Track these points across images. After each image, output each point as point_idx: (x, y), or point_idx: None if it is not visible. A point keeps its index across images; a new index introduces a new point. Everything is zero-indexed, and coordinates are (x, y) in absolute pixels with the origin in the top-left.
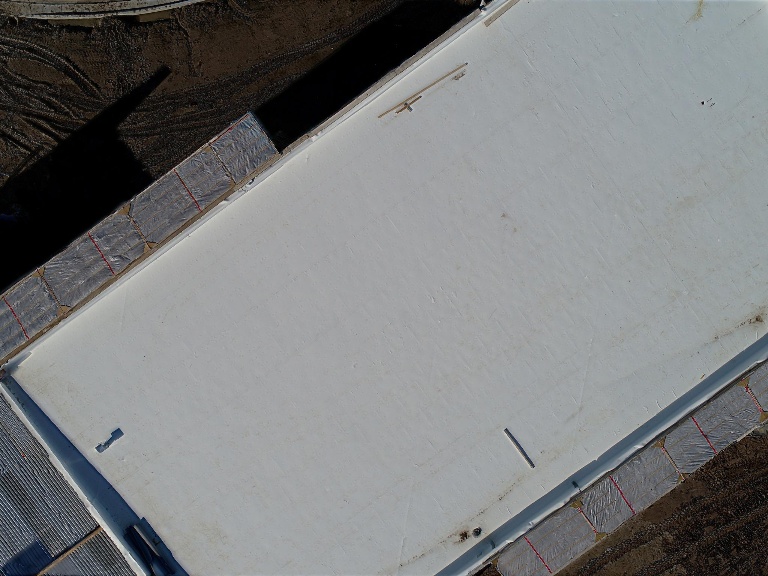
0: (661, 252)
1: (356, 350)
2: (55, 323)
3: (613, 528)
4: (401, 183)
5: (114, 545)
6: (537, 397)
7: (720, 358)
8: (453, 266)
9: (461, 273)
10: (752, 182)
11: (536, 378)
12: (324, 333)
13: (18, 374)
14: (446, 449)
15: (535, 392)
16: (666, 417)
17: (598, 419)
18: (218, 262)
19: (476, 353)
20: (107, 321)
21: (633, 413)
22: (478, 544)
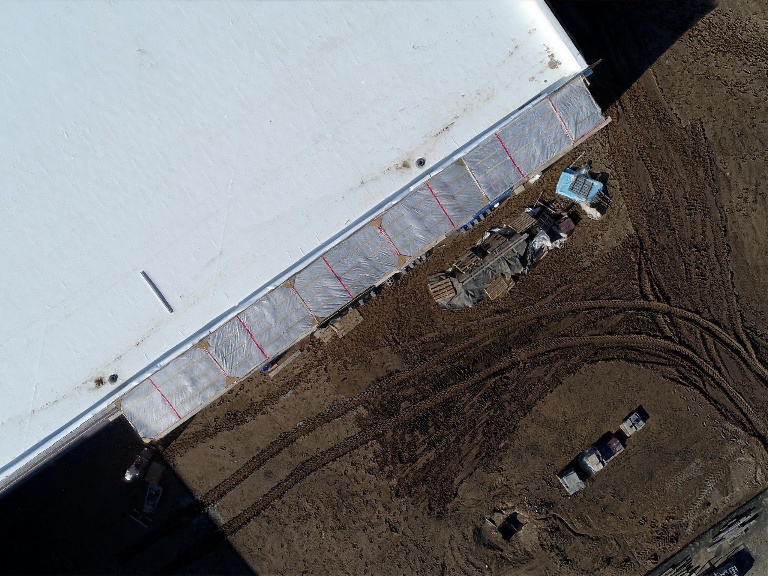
0: (303, 92)
1: None
2: None
3: (244, 372)
4: (31, 13)
5: None
6: (175, 239)
7: (365, 203)
8: (87, 101)
9: (95, 108)
10: (396, 23)
11: (174, 219)
12: None
13: None
14: (80, 291)
15: (173, 234)
16: None
17: (239, 263)
18: None
19: (111, 191)
20: None
21: (275, 258)
22: (114, 391)
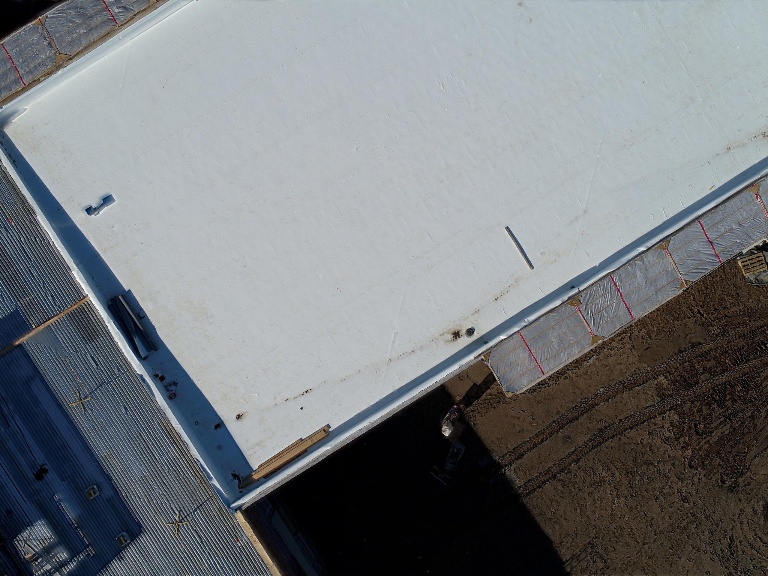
0: (678, 55)
1: (359, 132)
2: (53, 72)
3: (610, 332)
4: None
5: (97, 318)
6: (541, 196)
7: (731, 170)
8: (465, 53)
9: (472, 61)
10: None
11: (541, 176)
12: (328, 112)
13: (12, 130)
14: (444, 243)
15: (539, 191)
16: (672, 223)
17: (602, 223)
18: (225, 29)
19: (482, 145)
20: (107, 82)
21: (638, 220)
22: (470, 344)
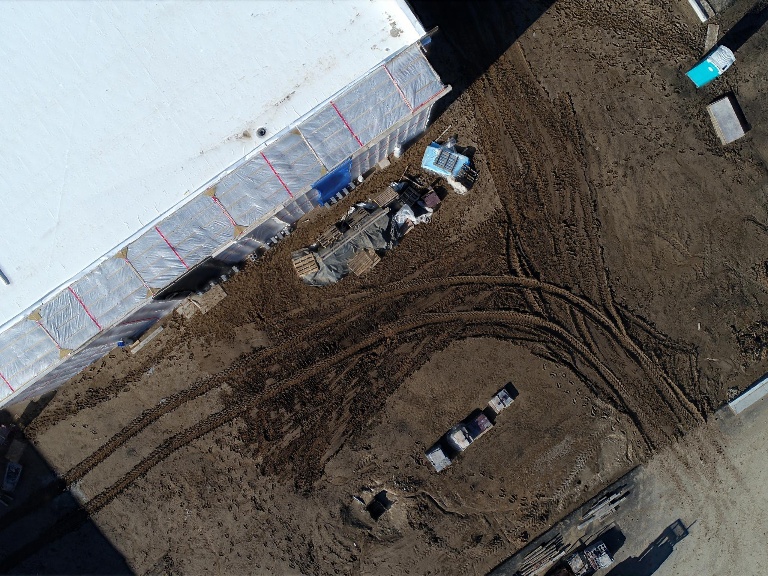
0: (140, 61)
1: None
2: None
3: (78, 344)
4: None
5: None
6: (11, 210)
7: (205, 174)
8: None
9: None
10: None
11: (10, 190)
12: None
13: None
14: None
15: (9, 204)
16: None
17: (76, 234)
18: None
19: None
20: None
21: (113, 229)
22: None
